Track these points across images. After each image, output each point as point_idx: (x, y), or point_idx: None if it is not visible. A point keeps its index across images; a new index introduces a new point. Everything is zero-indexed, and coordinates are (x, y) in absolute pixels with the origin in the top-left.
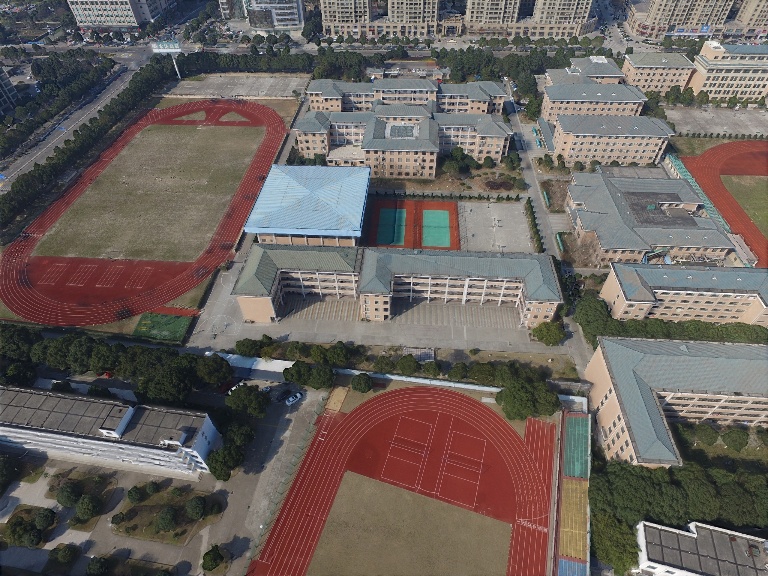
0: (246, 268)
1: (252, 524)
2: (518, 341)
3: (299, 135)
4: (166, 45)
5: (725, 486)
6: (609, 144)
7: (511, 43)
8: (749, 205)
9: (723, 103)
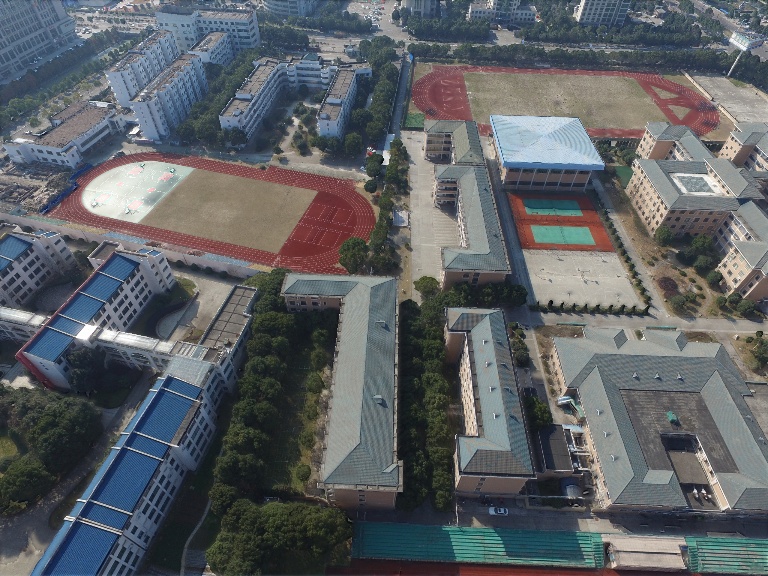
0: None
1: (294, 165)
2: (423, 275)
3: None
4: (741, 39)
5: None
6: None
7: None
8: None
9: None
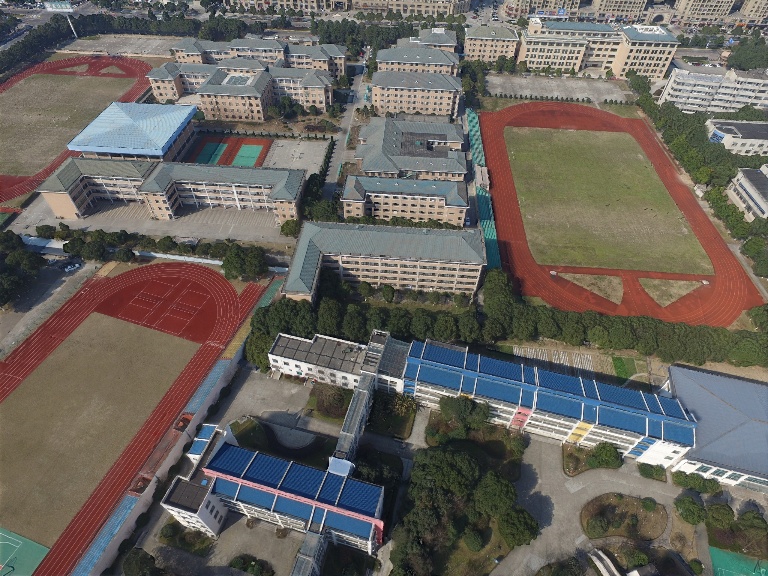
0: (55, 172)
1: (7, 341)
2: (270, 235)
3: (152, 82)
4: (59, 5)
5: None
6: (411, 96)
7: None
8: (514, 148)
9: (544, 73)
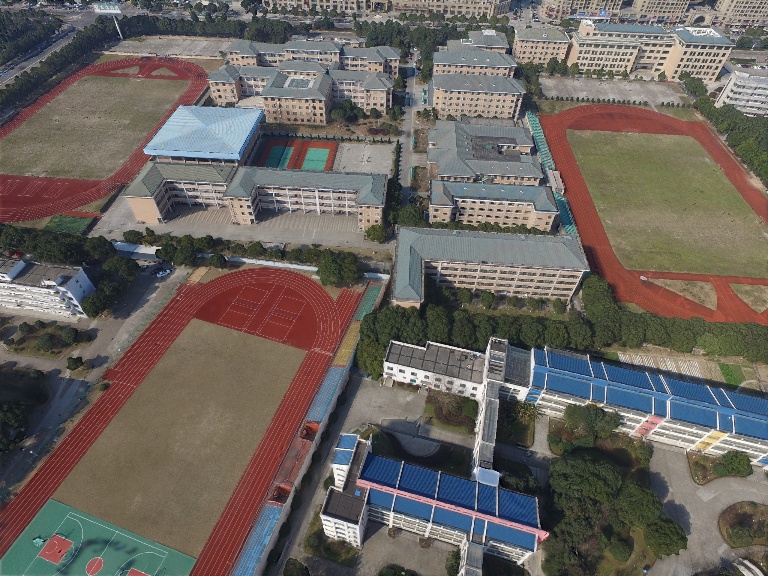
0: (137, 177)
1: (113, 348)
2: (354, 240)
3: (212, 85)
4: (107, 6)
5: (456, 320)
6: (473, 99)
7: None
8: (580, 152)
9: (595, 75)
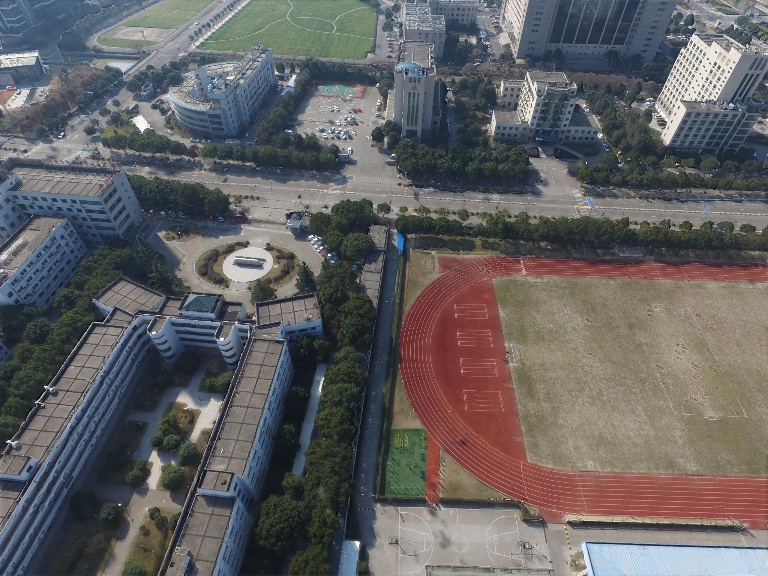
0: None
1: None
2: None
3: None
4: None
5: None
6: None
7: None
8: None
9: None
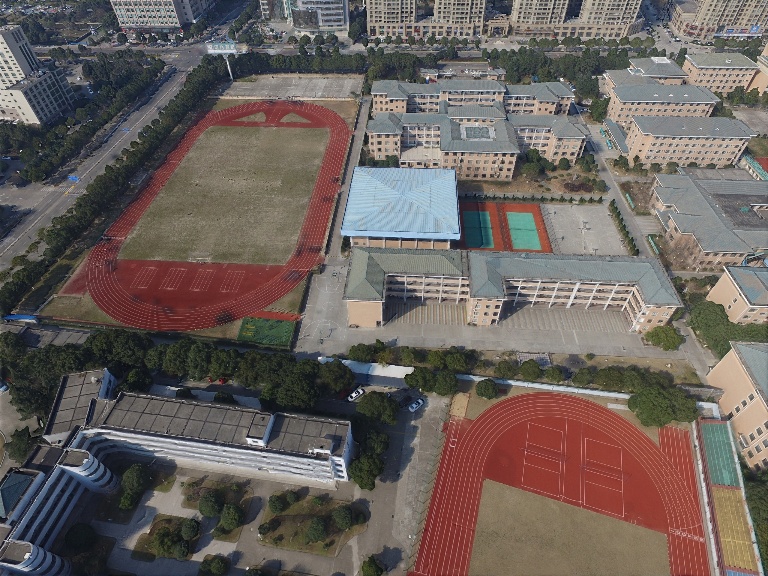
0: (353, 272)
1: (400, 534)
2: (631, 346)
3: (371, 137)
4: (222, 46)
5: None
6: (688, 145)
7: (559, 44)
8: None
9: None
